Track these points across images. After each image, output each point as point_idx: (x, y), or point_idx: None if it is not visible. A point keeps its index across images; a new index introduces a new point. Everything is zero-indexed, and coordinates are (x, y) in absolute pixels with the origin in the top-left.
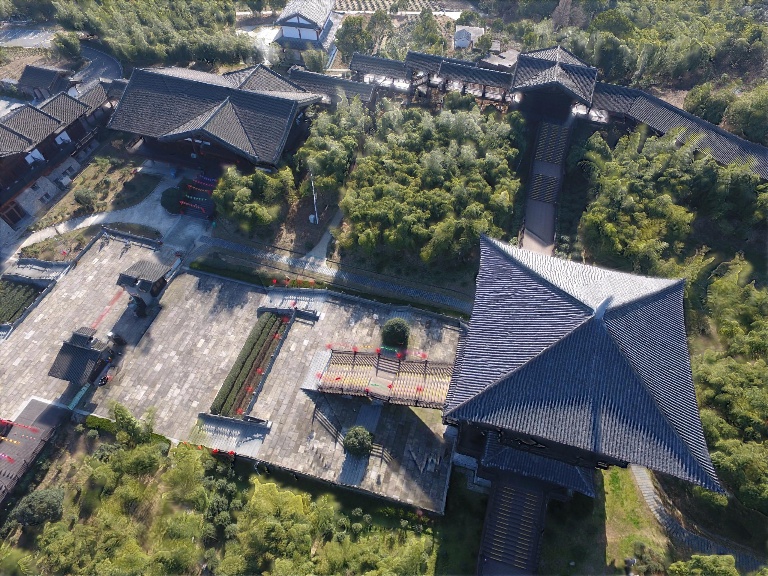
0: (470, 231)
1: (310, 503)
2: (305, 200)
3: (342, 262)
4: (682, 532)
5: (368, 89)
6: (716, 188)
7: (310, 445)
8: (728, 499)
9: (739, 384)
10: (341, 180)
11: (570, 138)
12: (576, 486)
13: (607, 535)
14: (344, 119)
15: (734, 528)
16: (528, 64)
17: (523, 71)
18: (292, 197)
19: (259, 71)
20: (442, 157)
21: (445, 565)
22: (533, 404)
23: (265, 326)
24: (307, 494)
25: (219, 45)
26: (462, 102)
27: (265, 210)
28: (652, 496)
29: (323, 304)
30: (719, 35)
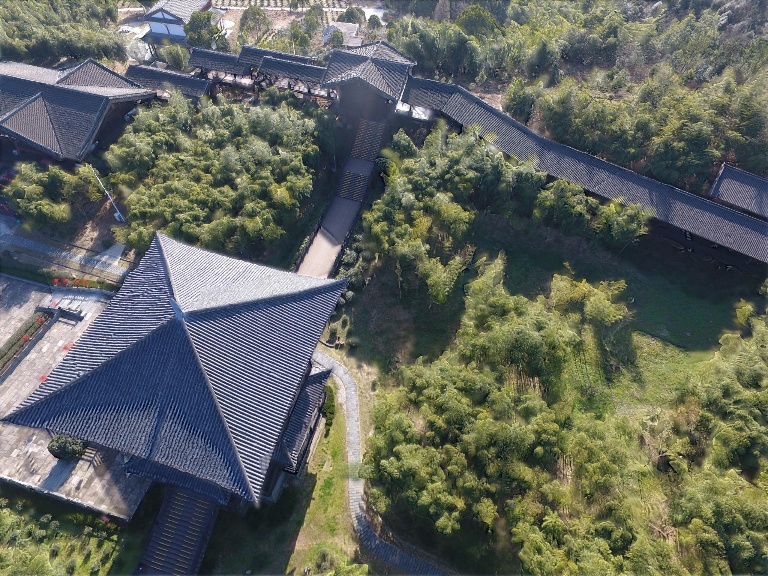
0: (243, 229)
1: (3, 509)
2: (121, 198)
3: (135, 261)
4: (374, 539)
5: (203, 85)
6: (499, 186)
7: (25, 449)
8: (387, 506)
9: (439, 387)
10: (144, 177)
11: (386, 135)
12: (211, 493)
13: (297, 542)
14: (162, 115)
15: (420, 536)
16: (341, 59)
17: (335, 67)
18: (95, 194)
19: (87, 66)
20: (236, 154)
21: (117, 573)
22: (99, 409)
23: (31, 326)
24: (3, 499)
25: (80, 40)
26: (281, 98)
27: (56, 208)
28: (358, 502)
29: (93, 304)
30: (573, 31)
